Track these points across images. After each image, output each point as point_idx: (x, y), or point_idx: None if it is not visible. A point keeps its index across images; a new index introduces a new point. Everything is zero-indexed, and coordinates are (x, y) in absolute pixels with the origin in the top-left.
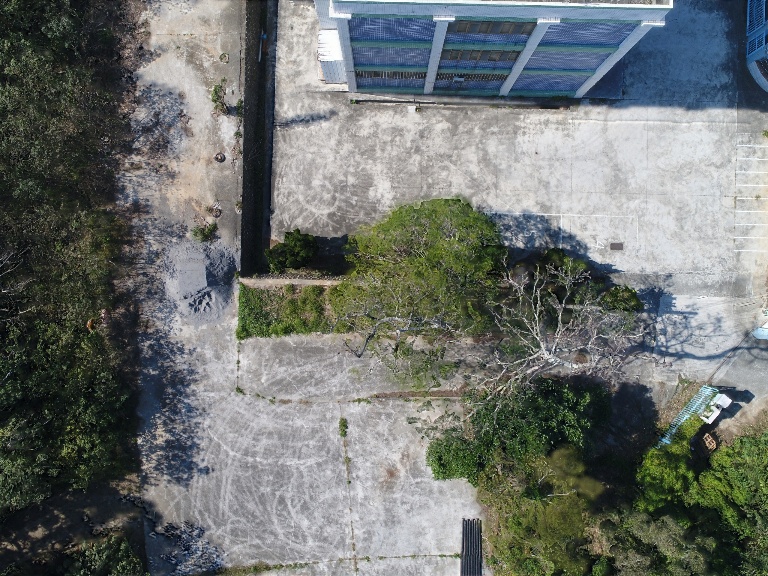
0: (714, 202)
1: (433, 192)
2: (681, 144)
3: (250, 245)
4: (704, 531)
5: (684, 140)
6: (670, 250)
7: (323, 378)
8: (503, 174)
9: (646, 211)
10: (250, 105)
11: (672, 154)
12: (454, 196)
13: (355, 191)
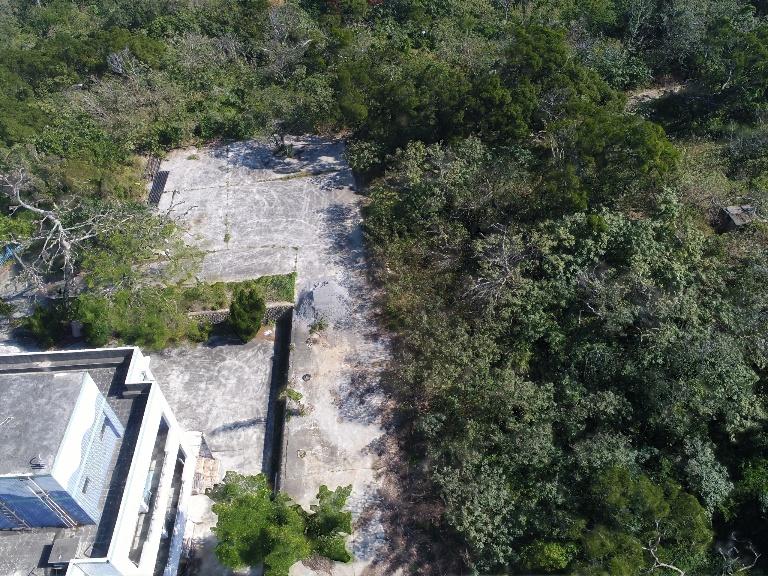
0: None
1: None
2: None
3: None
4: (4, 199)
5: None
6: None
7: (237, 260)
8: None
9: None
10: None
11: None
12: None
13: (201, 378)
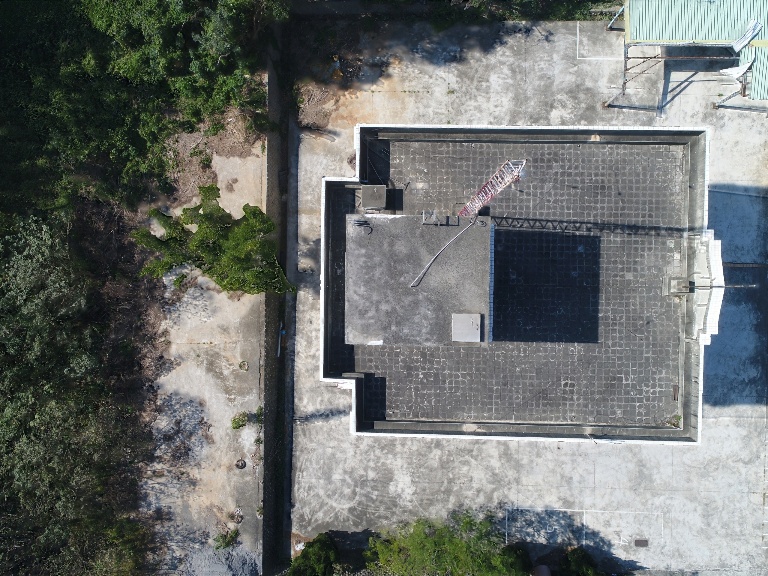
0: (742, 498)
1: (454, 487)
2: (708, 440)
3: (271, 540)
4: None
5: (711, 436)
6: (696, 547)
7: None
8: (525, 469)
9: (671, 507)
10: (270, 405)
11: (698, 450)
12: (475, 491)
13: (375, 486)
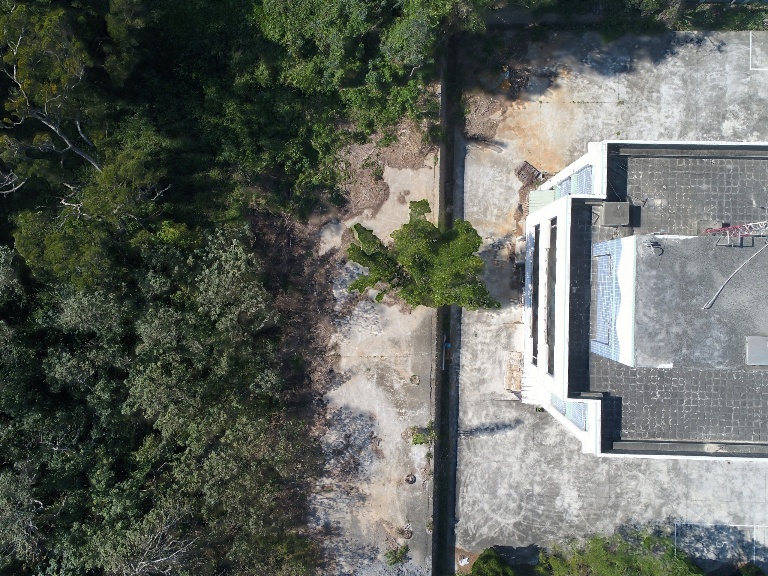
0: None
1: (621, 502)
2: None
3: (436, 556)
4: None
5: None
6: None
7: None
8: (694, 484)
9: None
10: (437, 419)
11: None
12: (643, 506)
13: (541, 500)
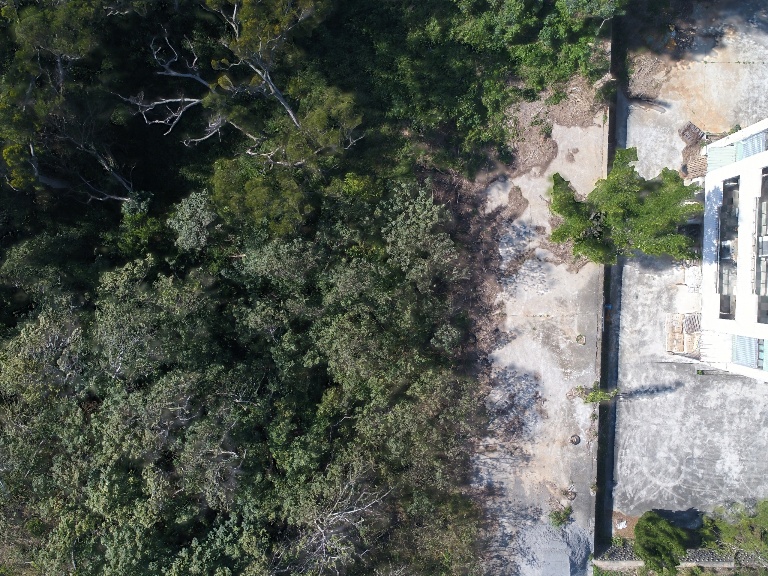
0: None
1: None
2: None
3: None
4: None
5: None
6: None
7: None
8: None
9: None
10: None
11: None
12: None
13: (701, 464)
